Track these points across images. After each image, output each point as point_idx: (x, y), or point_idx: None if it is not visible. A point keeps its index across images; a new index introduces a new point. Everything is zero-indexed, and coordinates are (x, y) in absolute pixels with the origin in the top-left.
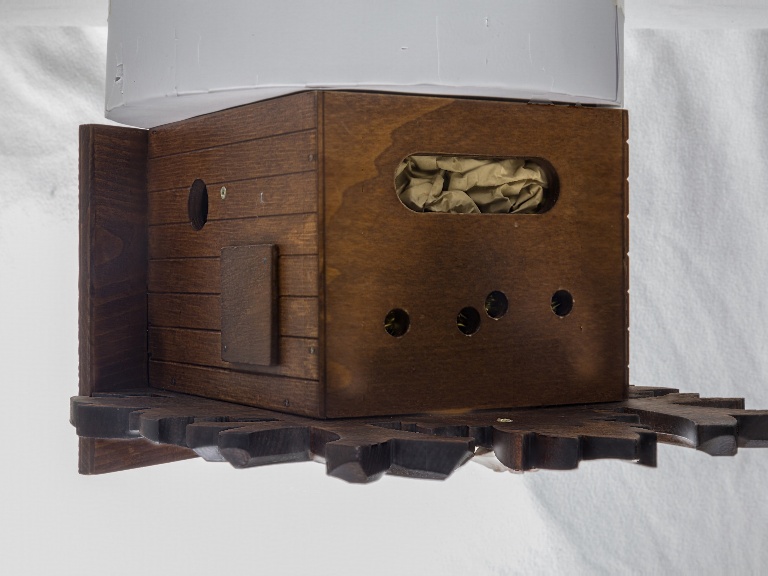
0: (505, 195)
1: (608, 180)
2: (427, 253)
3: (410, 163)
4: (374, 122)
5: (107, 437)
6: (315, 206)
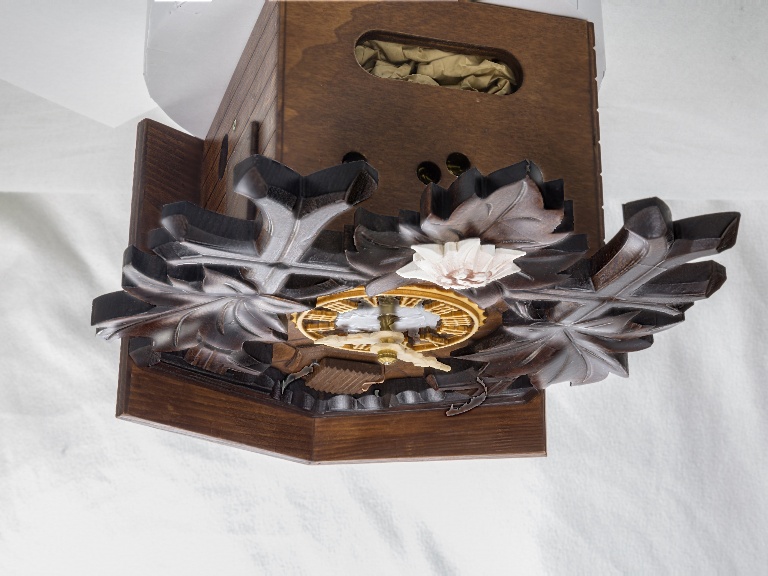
0: None
1: (574, 77)
2: (386, 111)
3: (379, 53)
4: (335, 0)
5: (113, 318)
6: (276, 59)
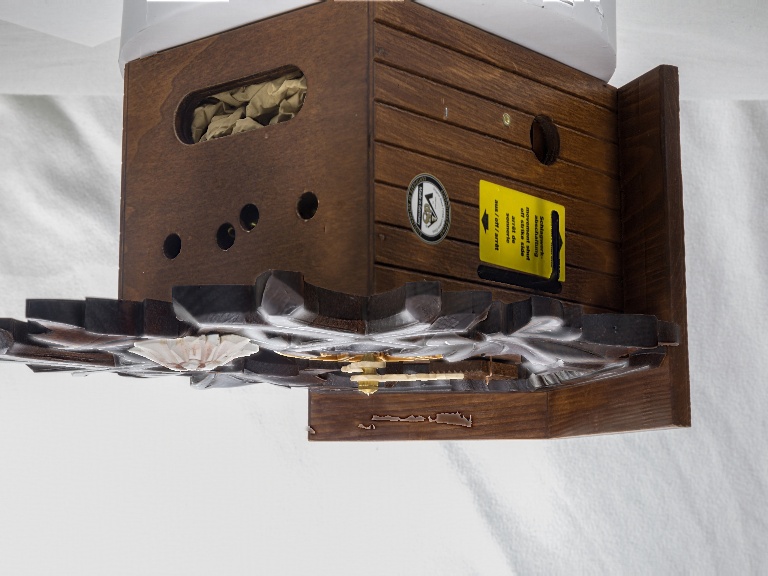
0: (295, 111)
1: (353, 68)
2: (195, 180)
3: (224, 104)
4: (161, 76)
5: None
6: None
